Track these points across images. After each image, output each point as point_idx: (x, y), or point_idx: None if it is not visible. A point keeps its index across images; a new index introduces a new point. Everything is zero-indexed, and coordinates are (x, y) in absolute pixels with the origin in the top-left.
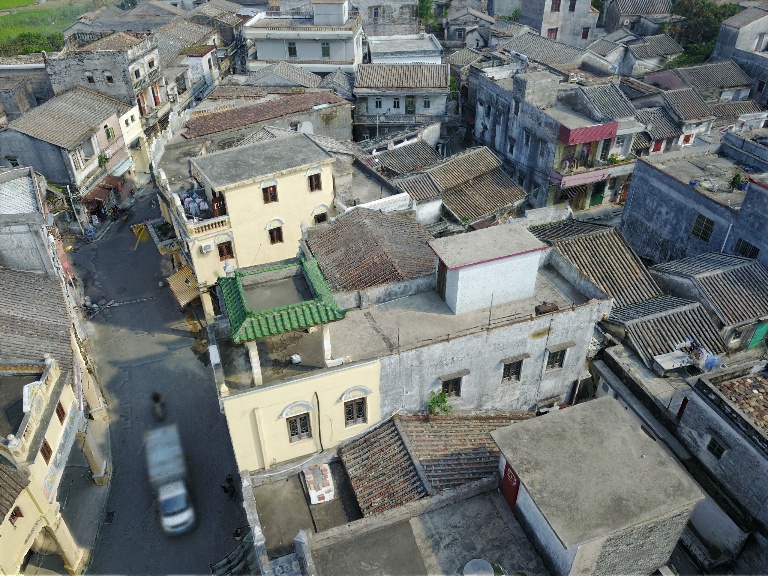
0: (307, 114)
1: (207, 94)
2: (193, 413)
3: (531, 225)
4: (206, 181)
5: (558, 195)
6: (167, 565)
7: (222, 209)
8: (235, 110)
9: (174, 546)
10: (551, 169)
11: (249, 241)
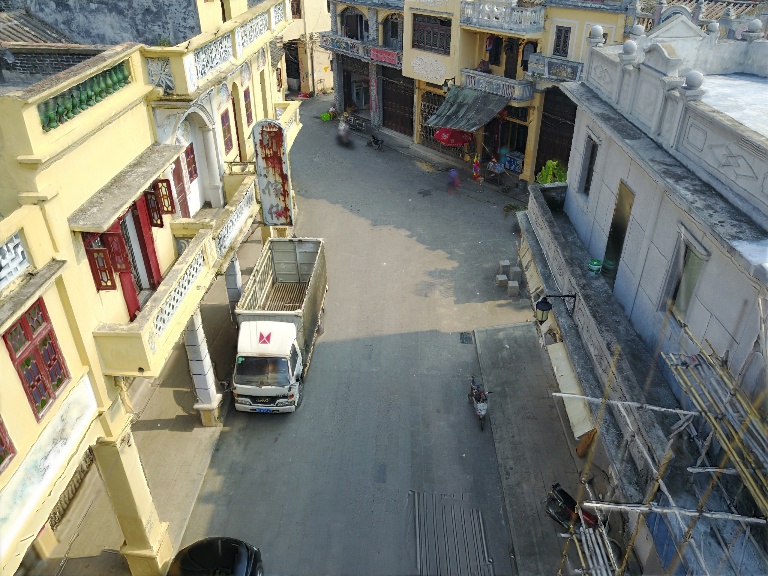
0: None
1: None
2: (304, 129)
3: None
4: None
5: None
6: (358, 176)
7: None
8: None
9: (354, 170)
10: None
11: (313, 2)
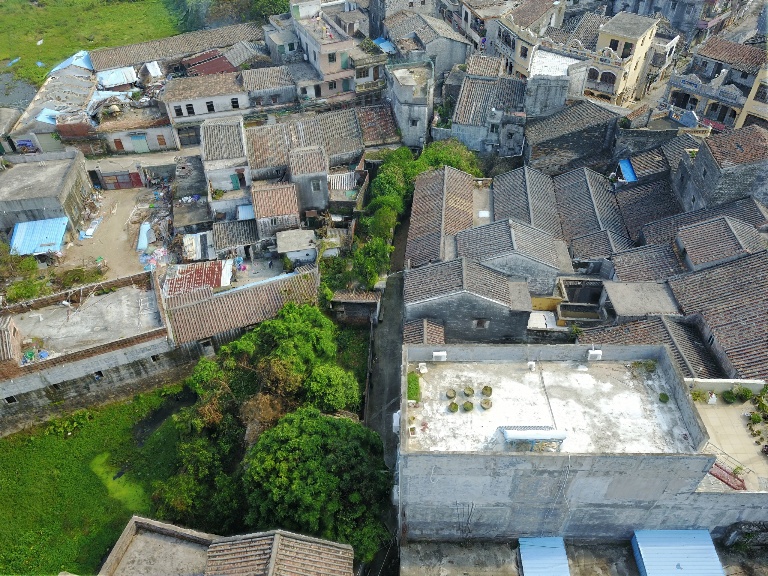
0: (555, 8)
1: (468, 6)
2: None
3: (747, 39)
4: (625, 37)
5: (694, 36)
6: None
7: (629, 52)
8: (516, 11)
9: None
10: (697, 20)
11: None
